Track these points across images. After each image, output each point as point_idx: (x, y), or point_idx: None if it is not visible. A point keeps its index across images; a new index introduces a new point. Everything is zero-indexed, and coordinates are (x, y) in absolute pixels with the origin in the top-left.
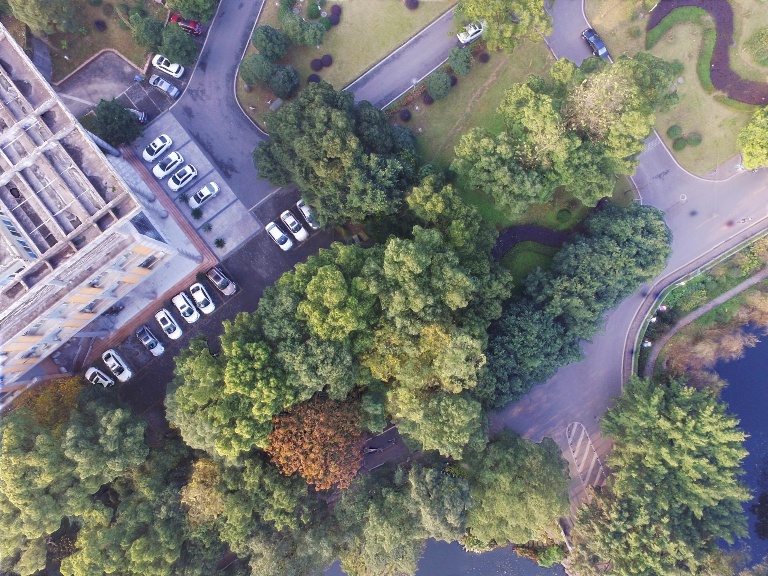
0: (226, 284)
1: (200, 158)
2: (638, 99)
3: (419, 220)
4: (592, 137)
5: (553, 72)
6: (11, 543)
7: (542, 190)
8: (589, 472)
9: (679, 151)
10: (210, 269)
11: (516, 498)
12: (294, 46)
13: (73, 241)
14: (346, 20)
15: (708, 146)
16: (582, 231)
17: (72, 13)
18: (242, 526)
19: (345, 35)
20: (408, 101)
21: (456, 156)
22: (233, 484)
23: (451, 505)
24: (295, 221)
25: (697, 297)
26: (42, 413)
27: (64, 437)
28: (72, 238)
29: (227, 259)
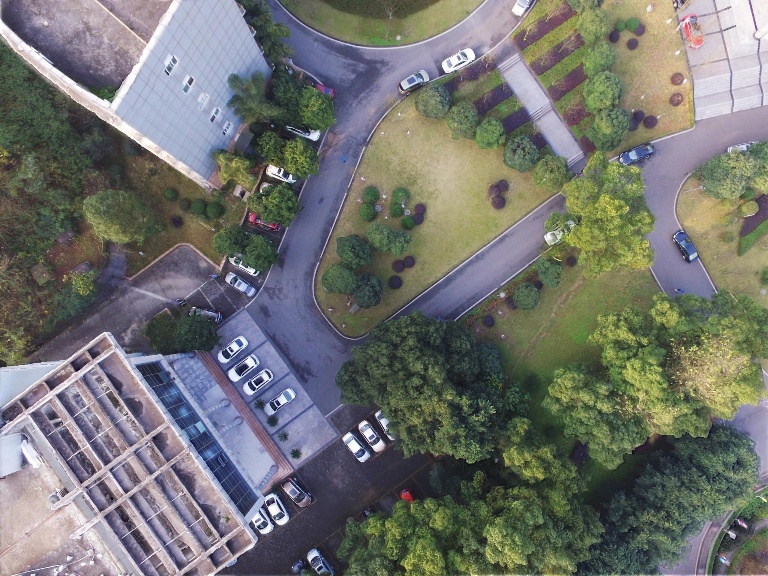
0: (302, 497)
1: (276, 360)
2: (751, 370)
3: None
4: (695, 391)
5: (655, 315)
6: None
7: None
8: None
9: None
10: (286, 482)
11: None
12: None
13: (185, 574)
14: (430, 219)
15: None
16: (666, 449)
17: (152, 221)
18: None
19: (428, 234)
20: (492, 307)
21: (550, 396)
22: None
23: None
24: (374, 434)
25: None
26: None
27: None
28: None
29: (302, 467)
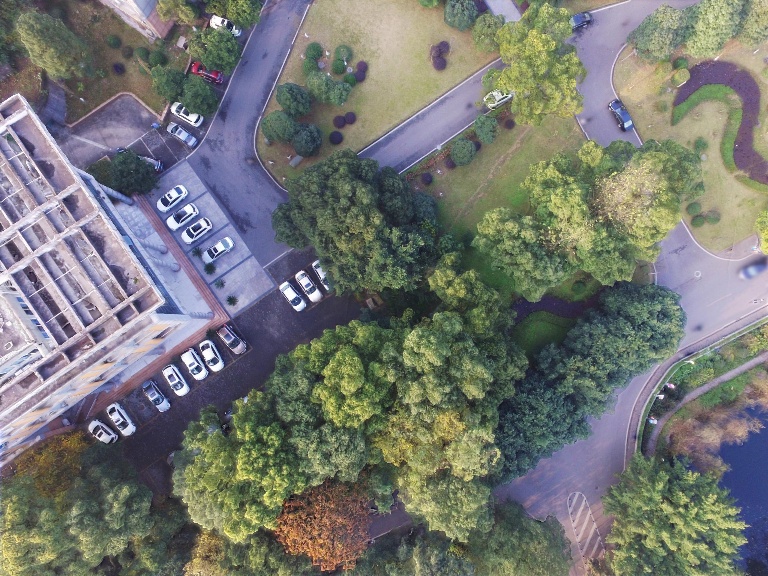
0: (237, 343)
1: (216, 211)
2: (666, 195)
3: None
4: (616, 225)
5: (581, 155)
6: None
7: (563, 275)
8: (587, 542)
9: (697, 228)
10: (221, 327)
11: None
12: (318, 103)
13: (91, 332)
14: (372, 77)
15: (726, 225)
16: (597, 307)
17: (91, 58)
18: None
19: (370, 92)
20: (430, 165)
21: (478, 233)
22: (238, 561)
23: None
24: (310, 283)
25: (705, 375)
26: (45, 474)
27: (69, 512)
28: (91, 330)
29: (239, 316)
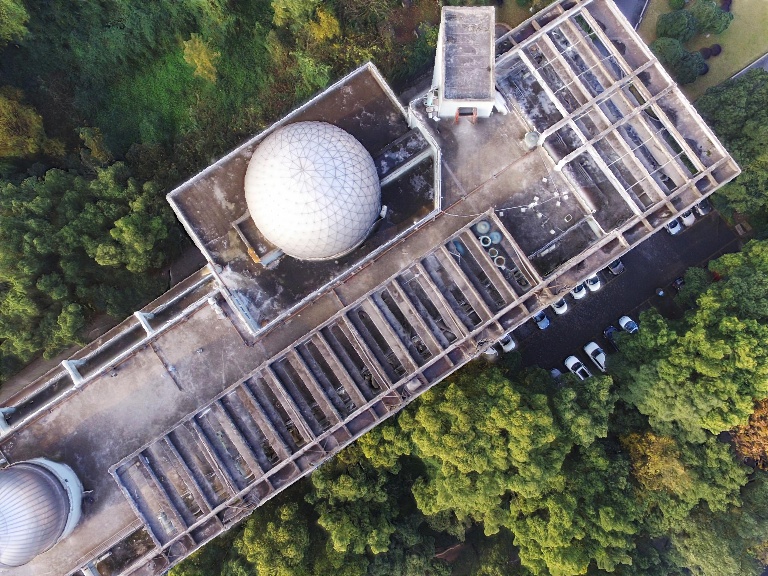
0: (616, 263)
1: None
2: None
3: None
4: None
5: None
6: (496, 501)
7: None
8: None
9: None
10: None
11: None
12: None
13: None
14: (734, 11)
15: None
16: None
17: None
18: None
19: (732, 26)
20: None
21: None
22: (697, 460)
23: None
24: None
25: None
26: None
27: (558, 399)
28: None
29: None
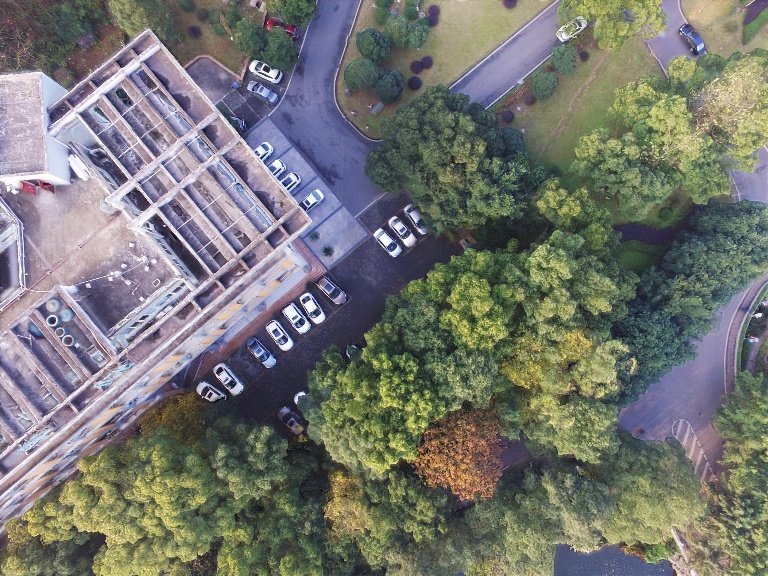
0: (337, 293)
1: (302, 165)
2: None
3: (535, 223)
4: (717, 135)
5: (673, 70)
6: (161, 566)
7: (667, 190)
8: (696, 468)
9: None
10: (320, 278)
11: (656, 500)
12: (396, 48)
13: (243, 259)
14: (445, 21)
15: None
16: (689, 229)
17: (173, 19)
18: (386, 539)
19: (444, 36)
20: (511, 102)
21: (577, 158)
22: (378, 497)
23: (596, 510)
24: (404, 227)
25: None
26: (170, 432)
27: (213, 457)
28: (243, 256)
29: (335, 267)
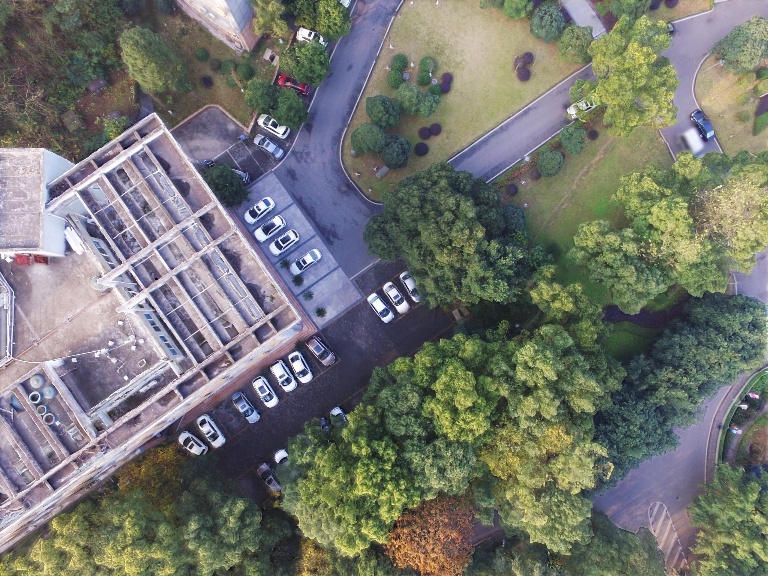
0: (326, 355)
1: (302, 222)
2: None
3: (528, 304)
4: (716, 238)
5: (678, 167)
6: None
7: None
8: (668, 552)
9: None
10: (311, 339)
11: None
12: (405, 114)
13: (229, 350)
14: (456, 88)
15: None
16: (682, 317)
17: None
18: None
19: (455, 104)
20: (515, 176)
21: (575, 246)
22: (347, 575)
23: None
24: (398, 294)
25: None
26: (147, 487)
27: (186, 527)
28: (229, 348)
29: (326, 328)
